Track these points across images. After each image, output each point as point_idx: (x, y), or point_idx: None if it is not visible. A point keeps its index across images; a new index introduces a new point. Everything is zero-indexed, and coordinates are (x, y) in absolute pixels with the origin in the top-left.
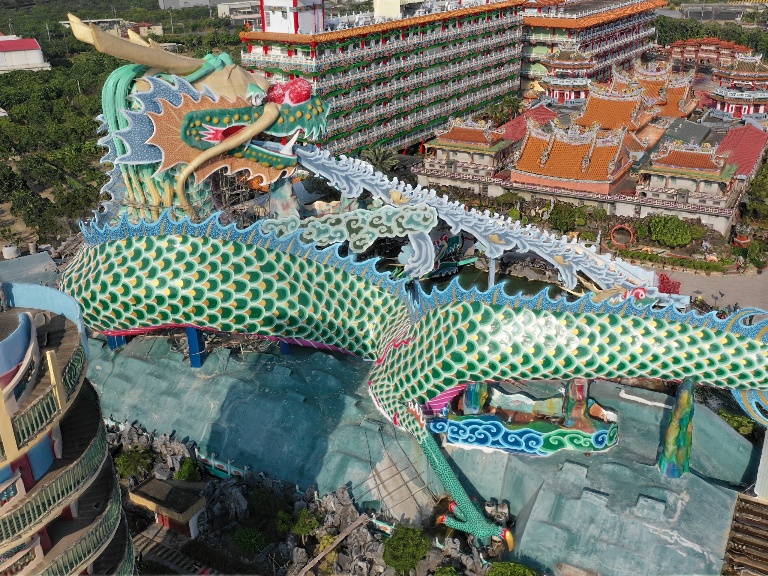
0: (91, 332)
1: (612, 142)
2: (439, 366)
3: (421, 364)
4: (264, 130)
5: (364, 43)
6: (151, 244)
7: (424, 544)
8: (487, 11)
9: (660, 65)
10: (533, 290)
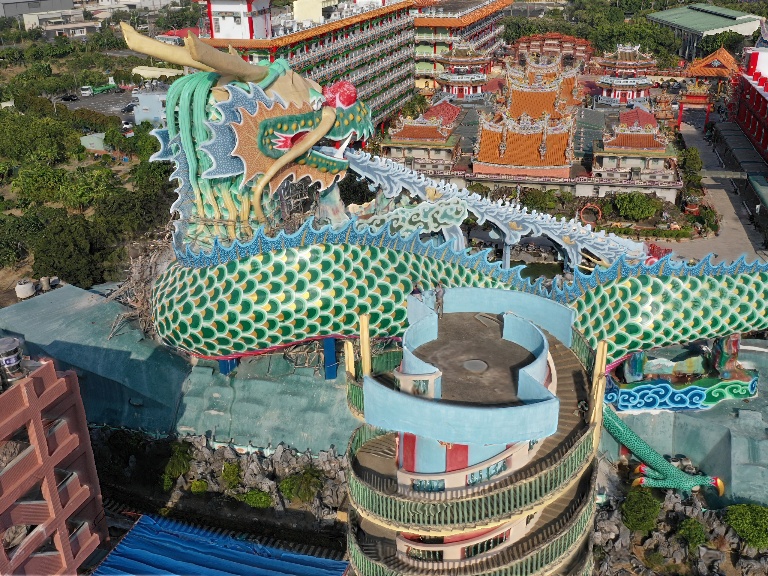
0: (188, 360)
1: (562, 129)
2: (612, 340)
3: (589, 341)
4: (325, 135)
5: (307, 47)
6: (292, 256)
7: (659, 503)
8: (389, 12)
9: (509, 60)
10: (535, 272)
